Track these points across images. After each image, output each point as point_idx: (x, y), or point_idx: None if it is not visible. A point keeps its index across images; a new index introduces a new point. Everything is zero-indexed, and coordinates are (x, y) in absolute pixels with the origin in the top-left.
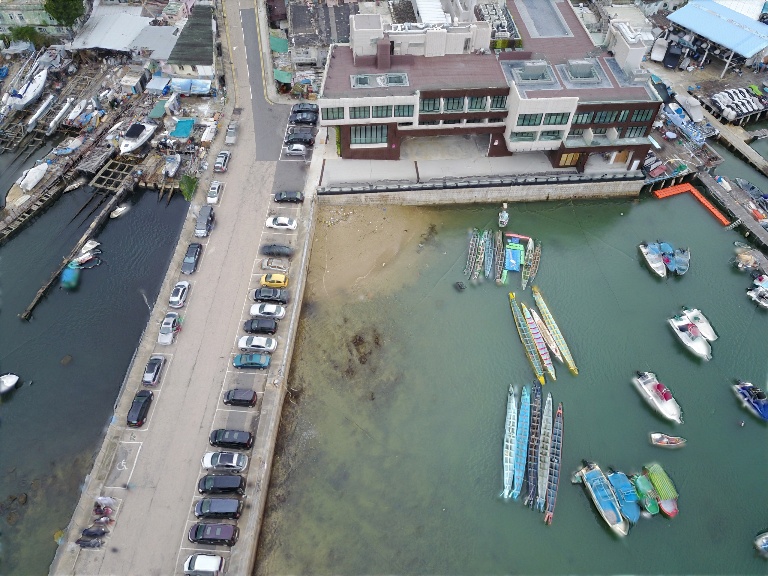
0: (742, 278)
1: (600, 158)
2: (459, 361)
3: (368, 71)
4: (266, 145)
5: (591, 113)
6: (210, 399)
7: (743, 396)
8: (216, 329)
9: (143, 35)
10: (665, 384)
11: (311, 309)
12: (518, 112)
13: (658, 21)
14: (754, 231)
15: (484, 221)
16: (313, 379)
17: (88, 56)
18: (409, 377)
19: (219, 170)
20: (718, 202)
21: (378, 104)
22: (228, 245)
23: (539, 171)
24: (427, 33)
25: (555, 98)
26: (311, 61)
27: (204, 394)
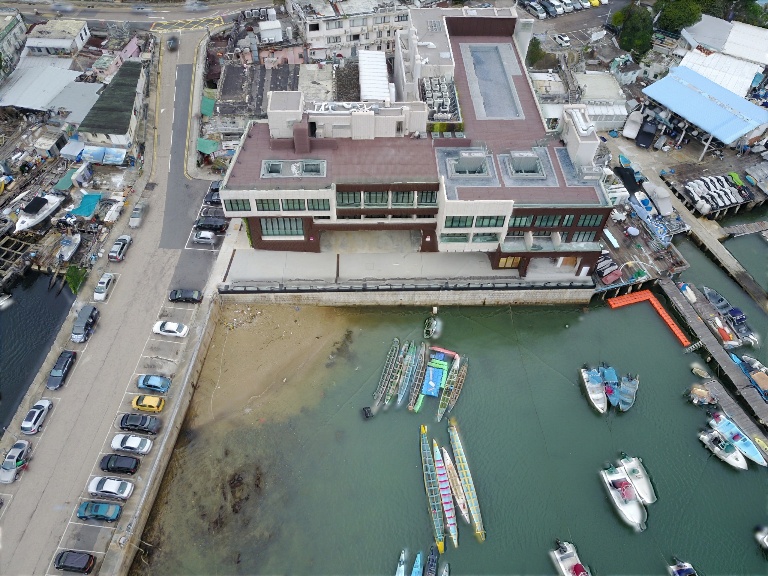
0: (697, 416)
1: (547, 259)
2: (350, 513)
3: (284, 156)
4: (173, 229)
5: (530, 217)
6: (41, 560)
7: None
8: (69, 464)
9: (65, 93)
10: (586, 561)
11: (191, 436)
12: (445, 214)
13: (634, 92)
14: (716, 357)
15: (407, 329)
16: (174, 530)
17: (8, 112)
18: (287, 533)
19: (114, 259)
20: (679, 316)
21: (288, 197)
22: (106, 353)
23: (475, 272)
24: (352, 115)
25: (486, 201)
26: (238, 131)
27: (36, 552)
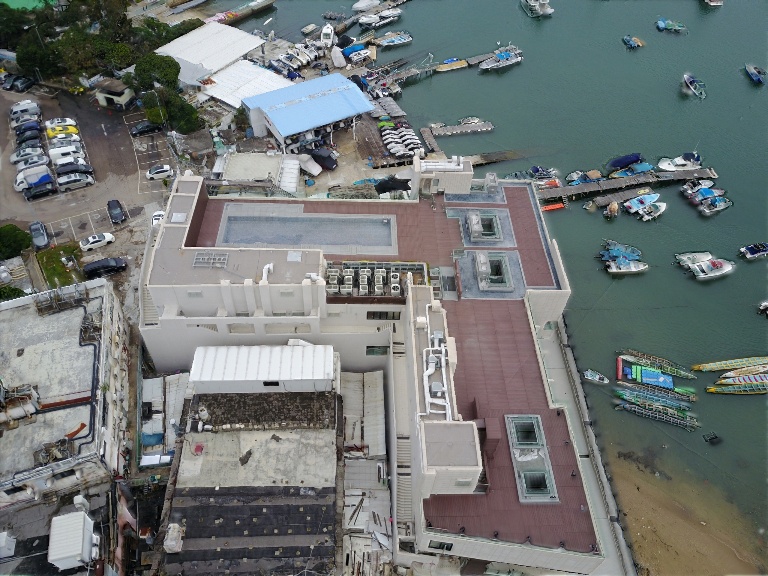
0: (623, 218)
1: None
2: None
3: (501, 472)
4: None
5: None
6: None
7: (764, 256)
8: None
9: None
10: None
11: None
12: None
13: (260, 147)
14: (577, 192)
15: (604, 396)
16: None
17: None
18: None
19: None
20: None
21: None
22: None
23: None
24: None
25: None
26: None
27: None
